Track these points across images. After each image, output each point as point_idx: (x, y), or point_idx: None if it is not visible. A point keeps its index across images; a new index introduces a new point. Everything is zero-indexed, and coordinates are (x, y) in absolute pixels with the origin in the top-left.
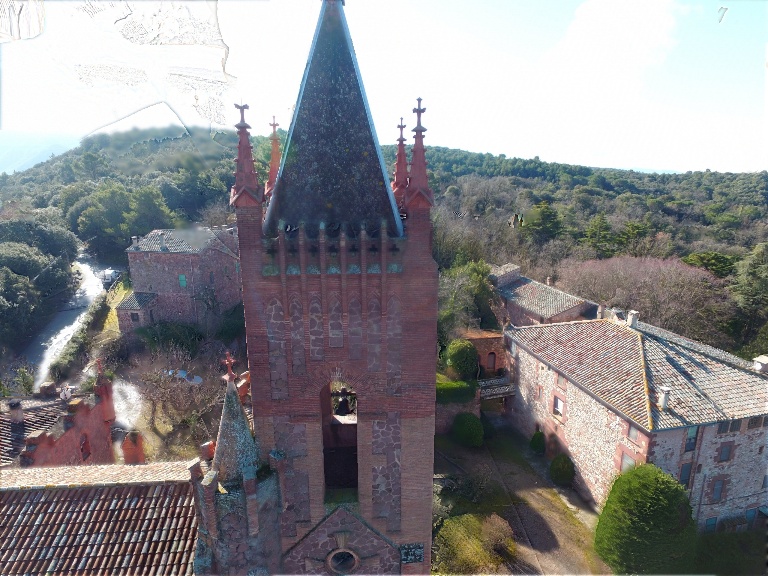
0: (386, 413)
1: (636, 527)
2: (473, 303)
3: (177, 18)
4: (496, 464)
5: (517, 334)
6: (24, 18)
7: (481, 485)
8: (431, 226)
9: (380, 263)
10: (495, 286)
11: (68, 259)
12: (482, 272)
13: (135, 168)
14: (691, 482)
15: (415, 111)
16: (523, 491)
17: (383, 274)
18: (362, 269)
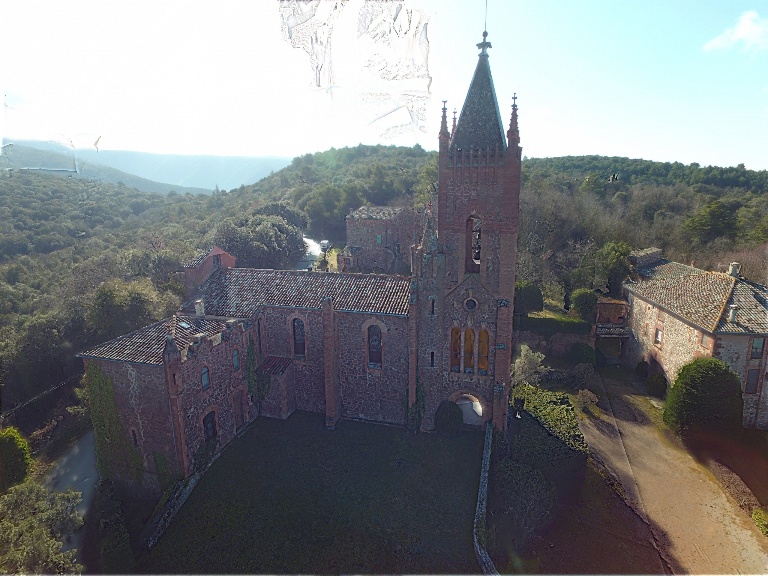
0: (494, 231)
1: (688, 393)
2: (601, 266)
3: (407, 65)
4: (601, 378)
5: (633, 286)
6: (322, 72)
7: (582, 380)
8: (520, 149)
9: (495, 161)
10: (634, 266)
11: (303, 230)
12: (621, 252)
13: (385, 141)
14: (759, 387)
15: (513, 98)
16: (619, 393)
17: (496, 166)
18: (487, 164)
